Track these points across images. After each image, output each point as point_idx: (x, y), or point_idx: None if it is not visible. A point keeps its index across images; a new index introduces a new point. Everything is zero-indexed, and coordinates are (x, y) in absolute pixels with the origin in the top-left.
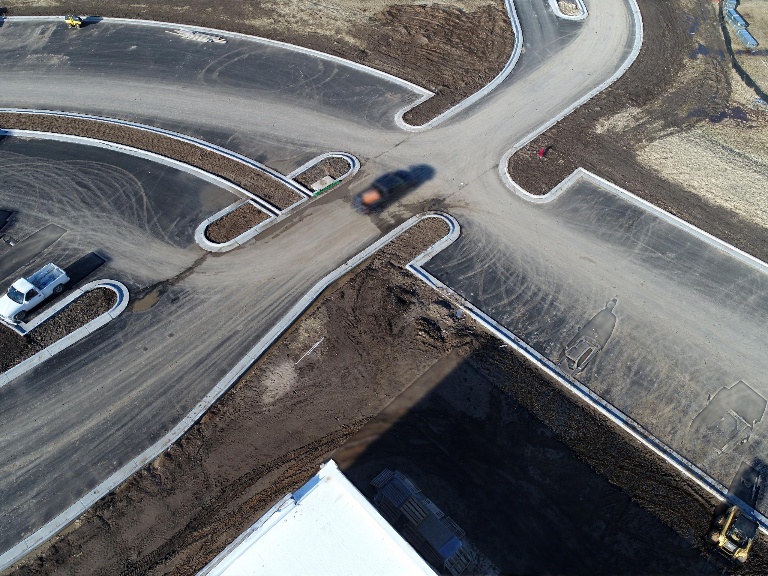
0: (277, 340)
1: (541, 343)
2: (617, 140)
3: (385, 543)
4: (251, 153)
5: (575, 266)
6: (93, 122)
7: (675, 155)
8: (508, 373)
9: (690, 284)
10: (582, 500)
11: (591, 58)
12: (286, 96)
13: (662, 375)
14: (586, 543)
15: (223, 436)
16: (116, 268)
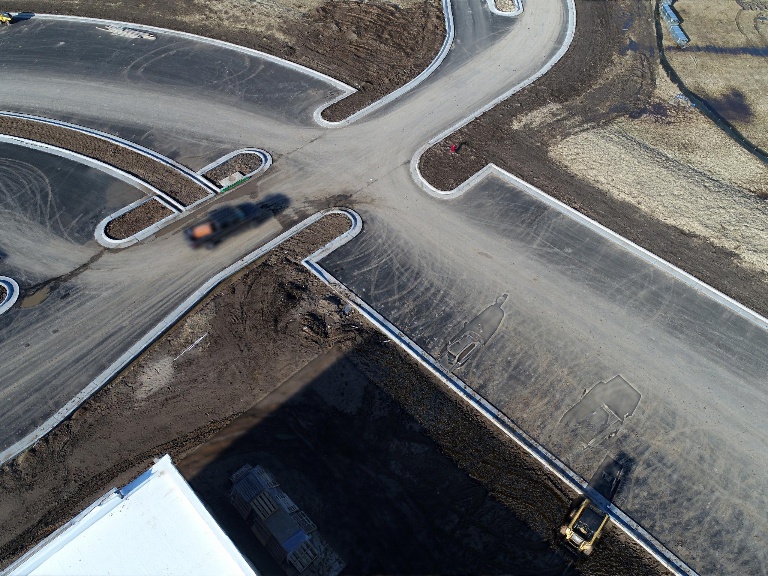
0: (161, 336)
1: (425, 338)
2: (532, 136)
3: (207, 537)
4: (164, 149)
5: (471, 262)
6: (9, 119)
7: (586, 151)
8: (387, 368)
9: (583, 279)
10: (439, 494)
11: (519, 54)
12: (208, 92)
13: (541, 370)
14: (436, 537)
15: (90, 432)
16: (10, 264)
